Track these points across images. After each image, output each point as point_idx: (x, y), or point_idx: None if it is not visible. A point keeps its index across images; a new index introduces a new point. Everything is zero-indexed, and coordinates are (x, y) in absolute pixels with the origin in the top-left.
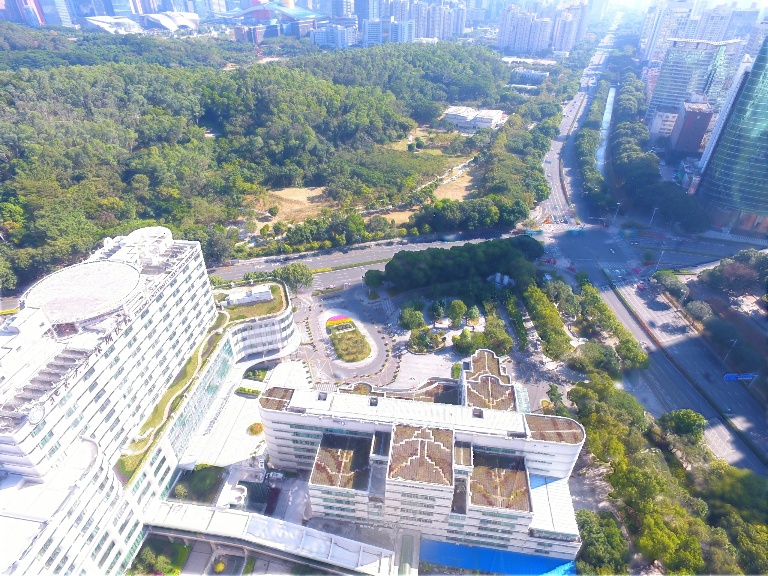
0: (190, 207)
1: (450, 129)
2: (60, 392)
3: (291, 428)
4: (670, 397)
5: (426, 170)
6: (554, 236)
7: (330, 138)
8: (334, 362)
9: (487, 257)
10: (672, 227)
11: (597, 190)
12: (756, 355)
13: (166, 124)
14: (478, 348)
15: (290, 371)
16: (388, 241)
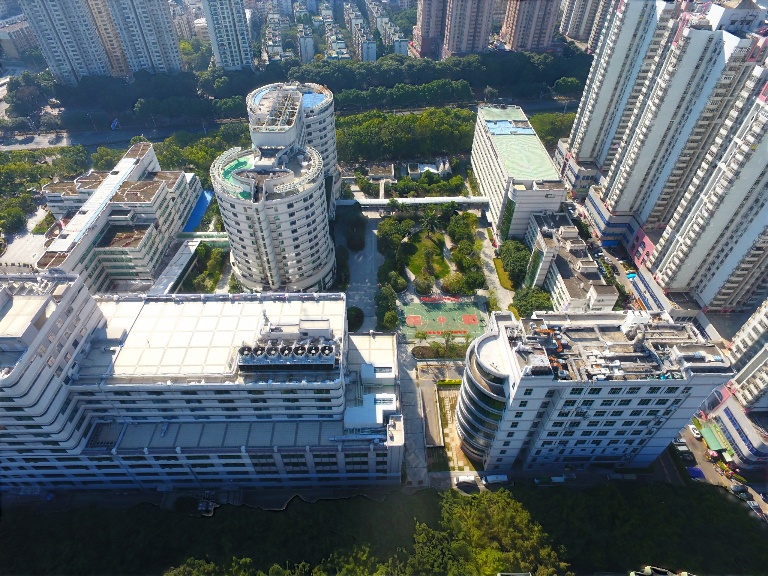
0: None
1: None
2: None
3: (82, 264)
4: None
5: None
6: None
7: None
8: None
9: None
10: None
11: None
12: (102, 114)
13: None
14: None
15: None
16: None
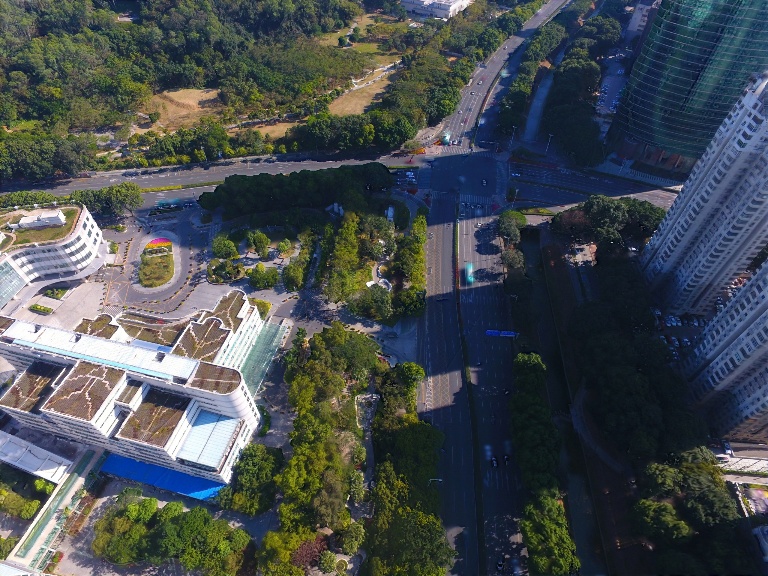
0: (69, 109)
1: (402, 17)
2: None
3: (10, 353)
4: (430, 346)
5: (333, 73)
6: (435, 161)
7: (252, 27)
8: (133, 286)
9: (320, 186)
10: (568, 157)
11: (508, 107)
12: (533, 313)
13: (67, 8)
14: (268, 283)
15: (89, 292)
16: (257, 157)
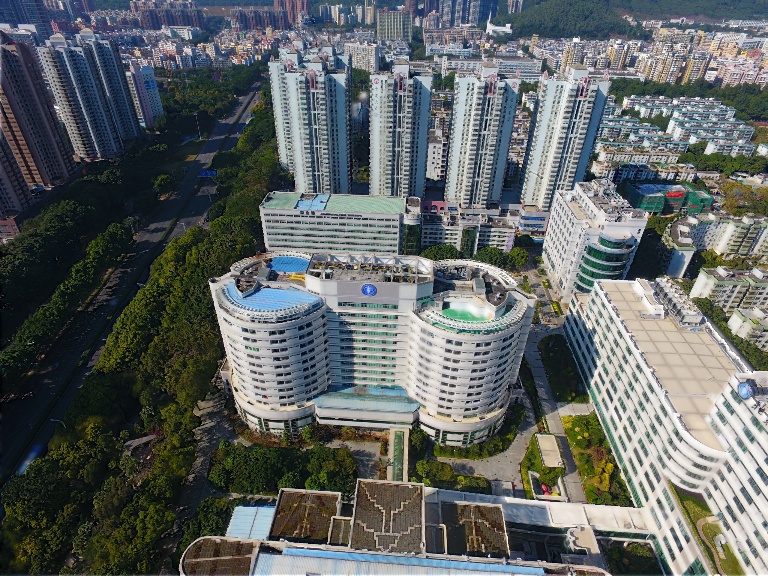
0: None
1: None
2: (762, 415)
3: None
4: None
5: None
6: None
7: None
8: None
9: None
10: None
11: None
12: None
13: None
14: None
15: None
16: None
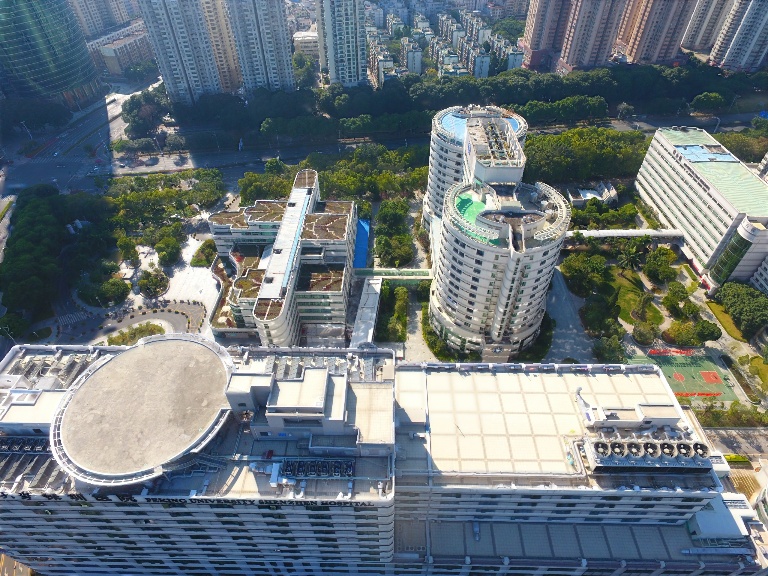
0: None
1: None
2: None
3: None
4: None
5: None
6: (3, 194)
7: None
8: None
9: None
10: (47, 130)
11: None
12: (226, 134)
13: None
14: None
15: None
16: None
